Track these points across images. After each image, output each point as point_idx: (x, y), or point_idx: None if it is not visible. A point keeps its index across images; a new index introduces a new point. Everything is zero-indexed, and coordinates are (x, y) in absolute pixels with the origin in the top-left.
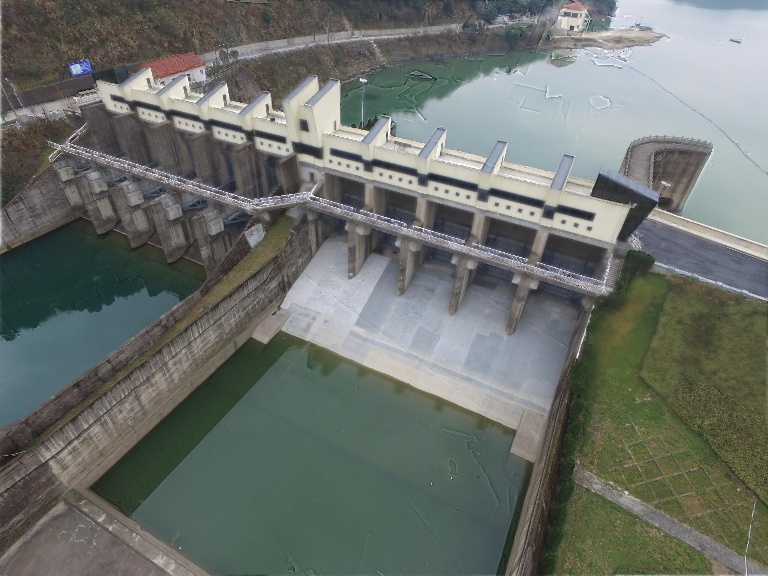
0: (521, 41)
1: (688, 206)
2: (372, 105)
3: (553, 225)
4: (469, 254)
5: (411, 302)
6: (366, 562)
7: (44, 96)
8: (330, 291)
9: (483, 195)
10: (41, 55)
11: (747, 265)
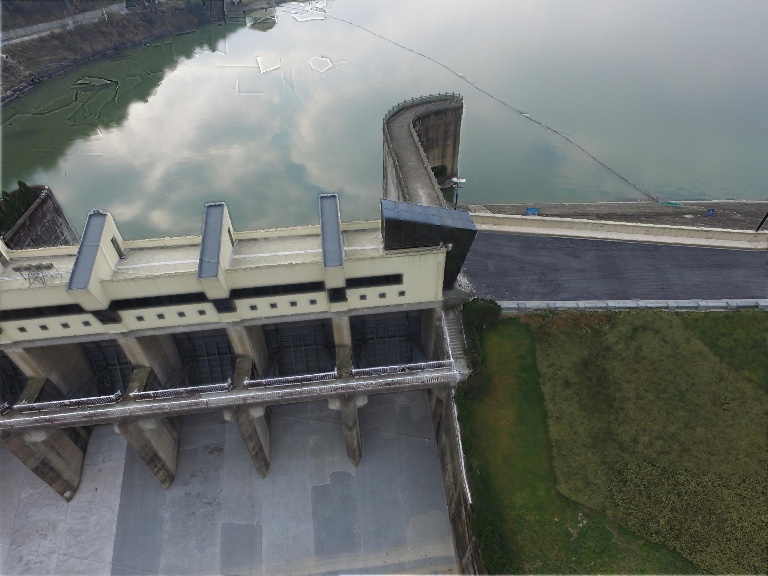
0: (207, 10)
1: (461, 167)
2: (30, 146)
3: (350, 306)
4: (246, 403)
5: (193, 488)
6: None
7: None
8: (39, 545)
9: (224, 305)
10: None
11: (585, 255)
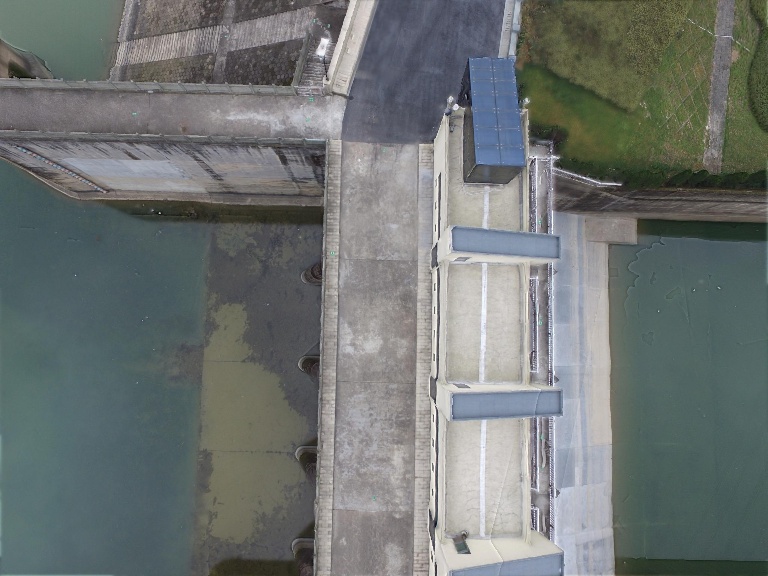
0: None
1: (7, 36)
2: None
3: None
4: None
5: None
6: (760, 336)
7: None
8: None
9: None
10: None
11: None
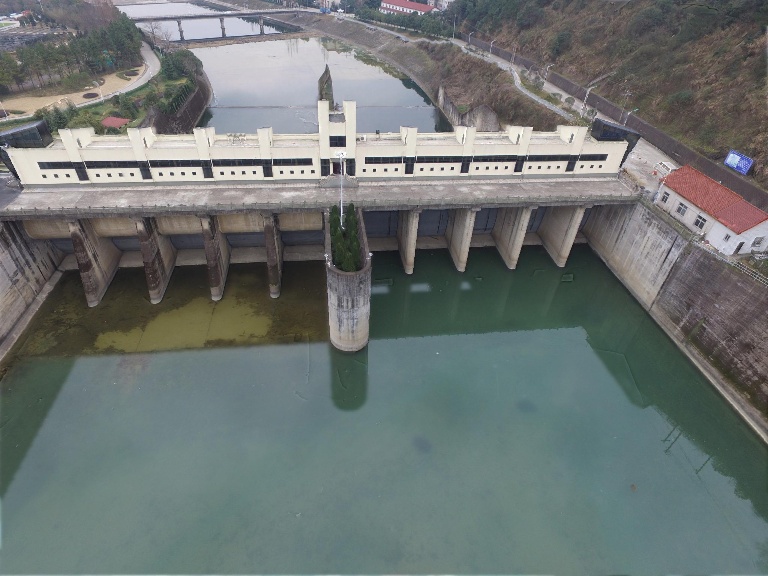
0: None
1: None
2: None
3: None
4: None
5: None
6: None
7: (683, 157)
8: None
9: None
10: (736, 131)
11: None
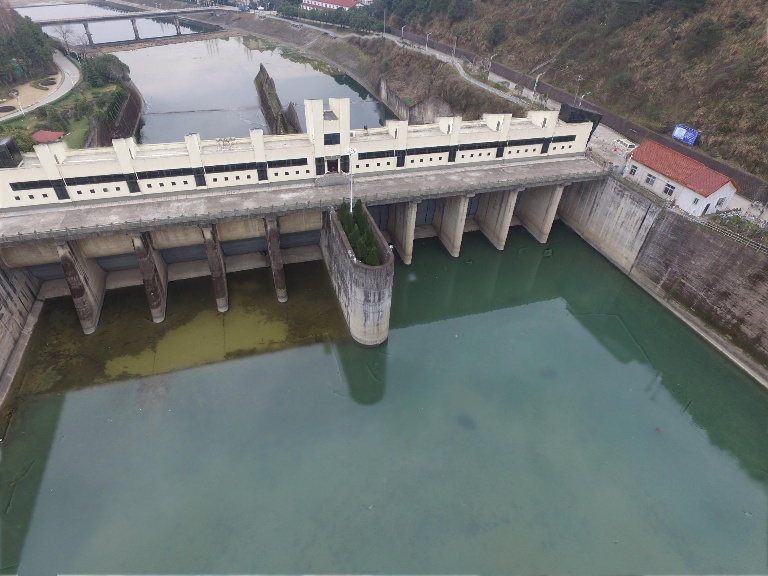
0: None
1: None
2: None
3: None
4: None
5: None
6: None
7: None
8: None
9: None
10: (678, 107)
11: None
